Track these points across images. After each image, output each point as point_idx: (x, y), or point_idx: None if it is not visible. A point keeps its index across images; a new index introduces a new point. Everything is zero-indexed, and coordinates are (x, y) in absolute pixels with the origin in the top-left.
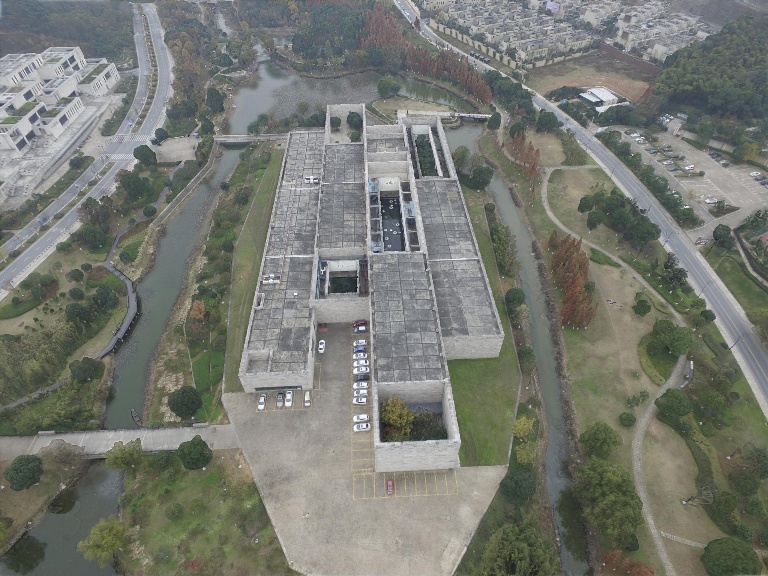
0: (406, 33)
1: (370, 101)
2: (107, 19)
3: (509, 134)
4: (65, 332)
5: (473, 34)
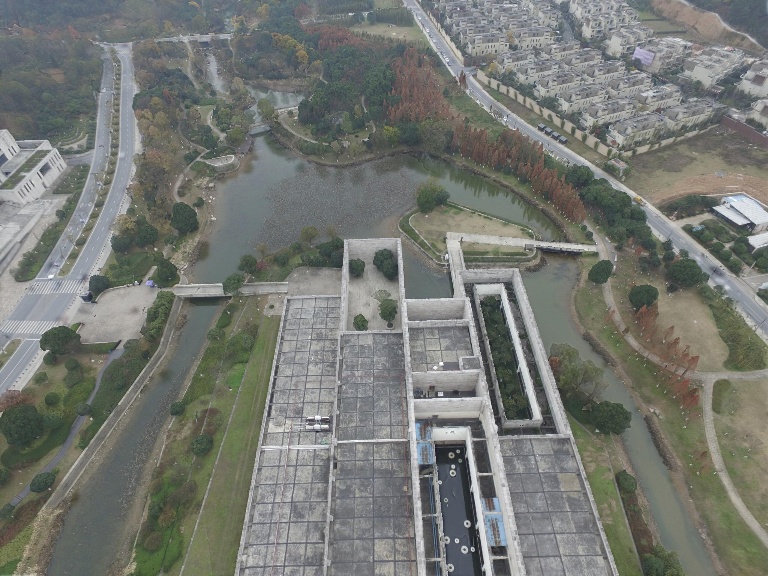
0: (448, 92)
1: (405, 210)
2: (66, 72)
3: (623, 291)
4: None
5: (539, 97)
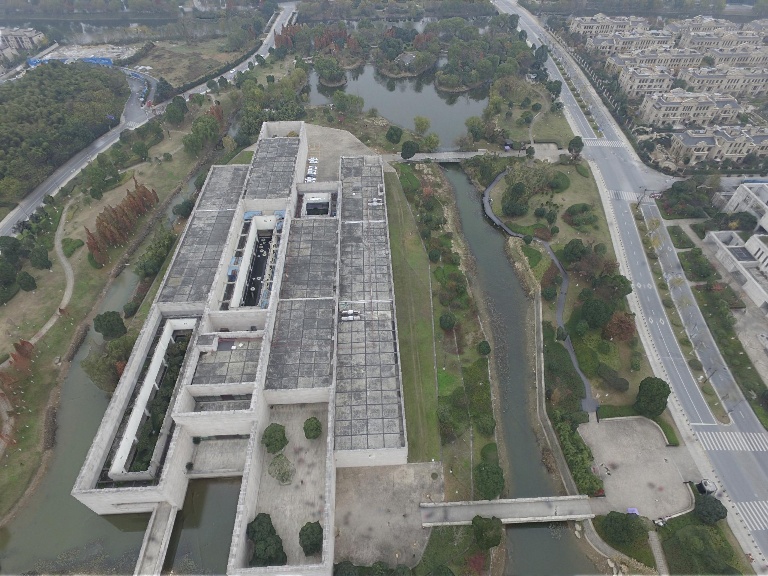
0: None
1: None
2: None
3: None
4: (516, 182)
5: None
